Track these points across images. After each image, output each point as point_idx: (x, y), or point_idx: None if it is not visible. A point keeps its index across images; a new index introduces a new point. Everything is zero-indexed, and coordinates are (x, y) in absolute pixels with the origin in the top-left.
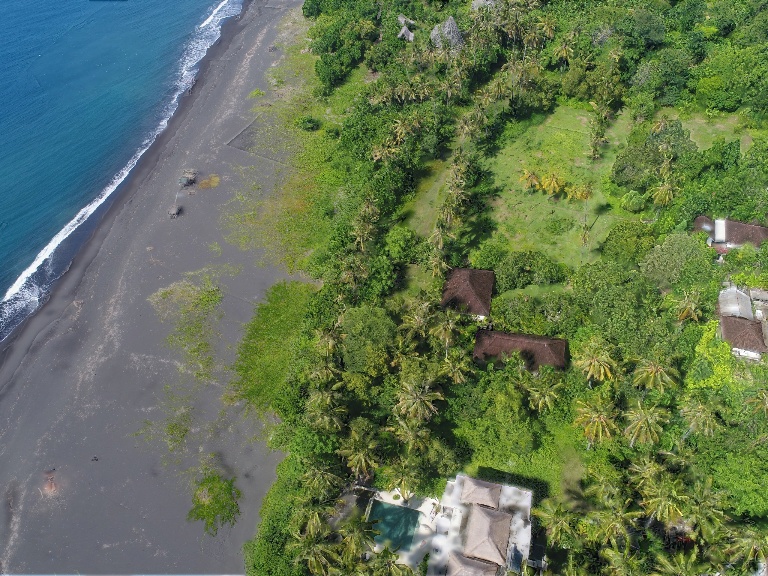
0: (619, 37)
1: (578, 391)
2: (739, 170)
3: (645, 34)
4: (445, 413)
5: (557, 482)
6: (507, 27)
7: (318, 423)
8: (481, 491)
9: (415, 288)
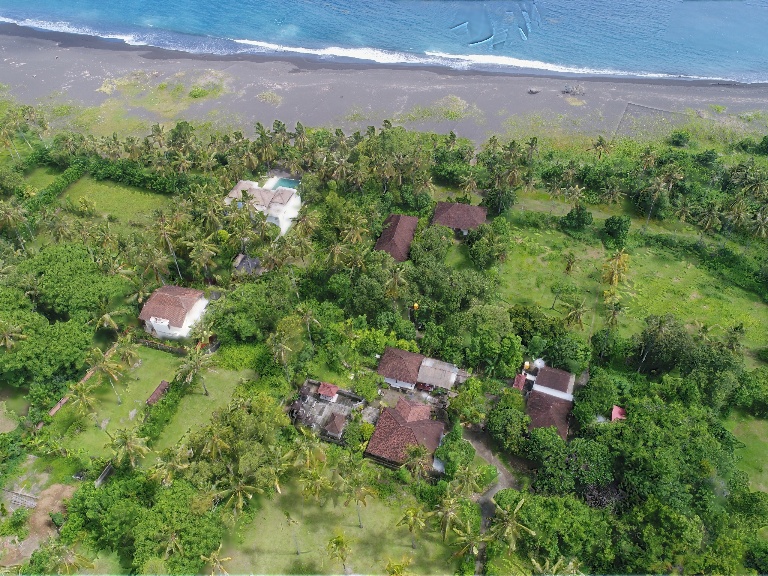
0: None
1: None
2: None
3: None
4: None
5: None
6: None
7: (334, 136)
8: None
9: (471, 201)
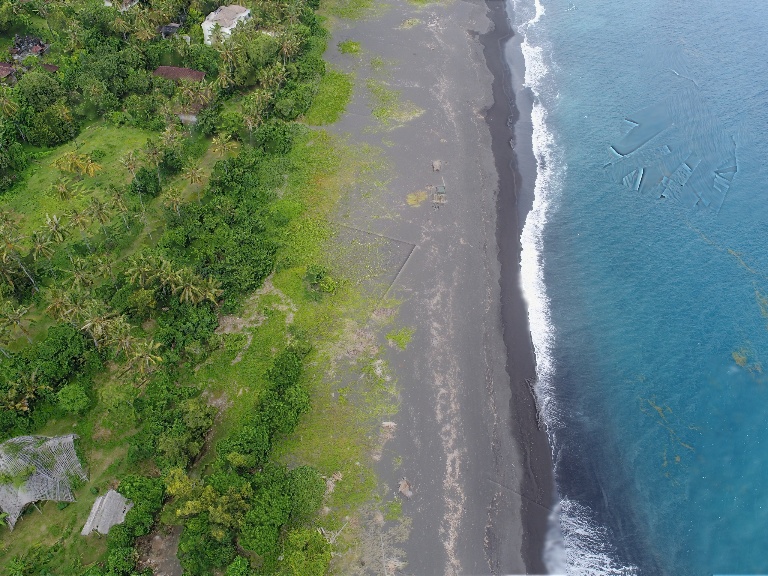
0: None
1: None
2: None
3: None
4: None
5: None
6: None
7: None
8: None
9: None
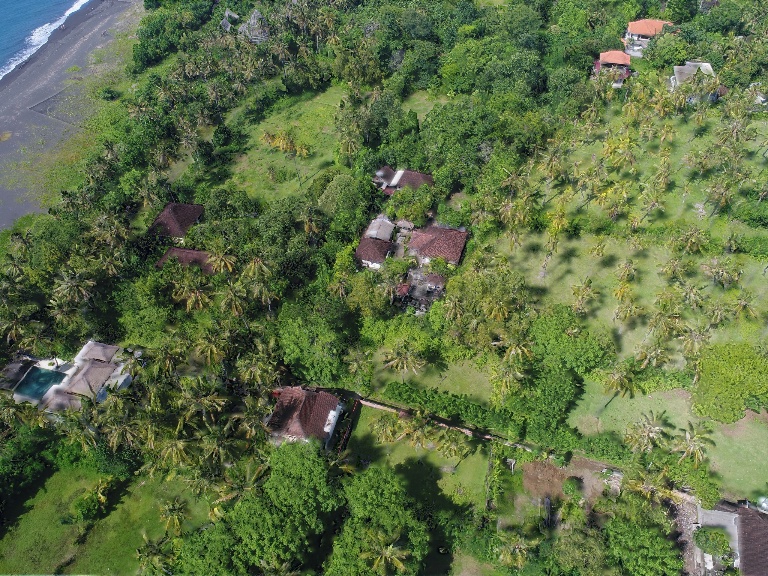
0: (386, 30)
1: (216, 286)
2: (420, 130)
3: (412, 29)
4: (116, 306)
5: (188, 355)
6: (296, 19)
7: None
8: (97, 349)
9: (142, 220)
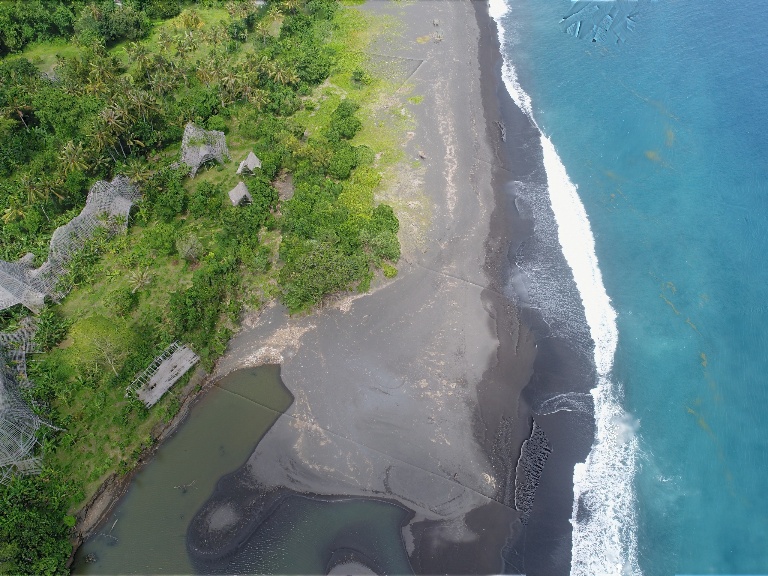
0: None
1: None
2: None
3: None
4: None
5: None
6: None
7: None
8: None
9: None
